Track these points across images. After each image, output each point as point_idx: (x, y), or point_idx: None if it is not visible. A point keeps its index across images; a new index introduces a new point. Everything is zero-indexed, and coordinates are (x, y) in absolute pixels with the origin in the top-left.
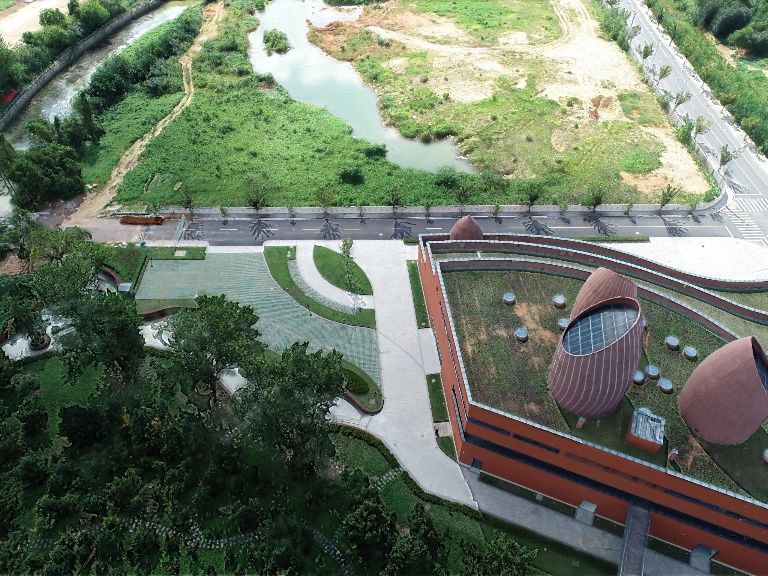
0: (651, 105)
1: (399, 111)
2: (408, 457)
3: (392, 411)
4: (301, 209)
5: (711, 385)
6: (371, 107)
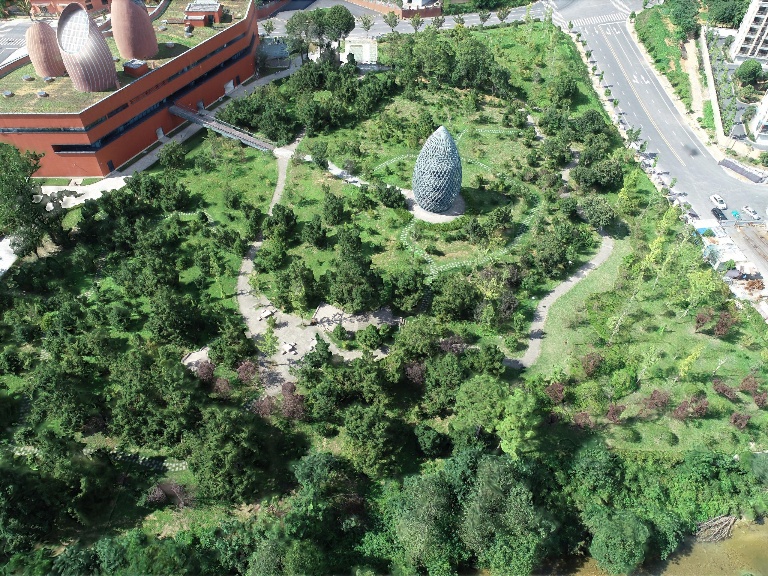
0: None
1: None
2: None
3: None
4: None
5: (128, 26)
6: None
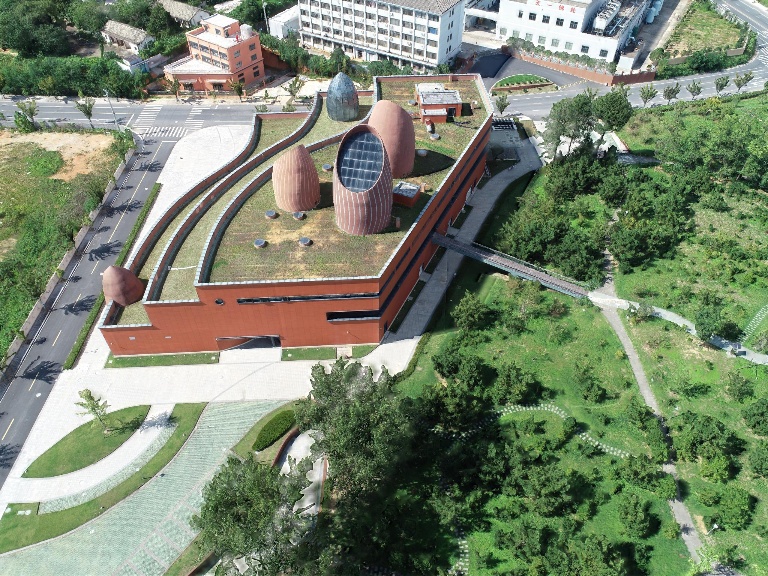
0: None
1: None
2: None
3: None
4: None
5: (396, 140)
6: None
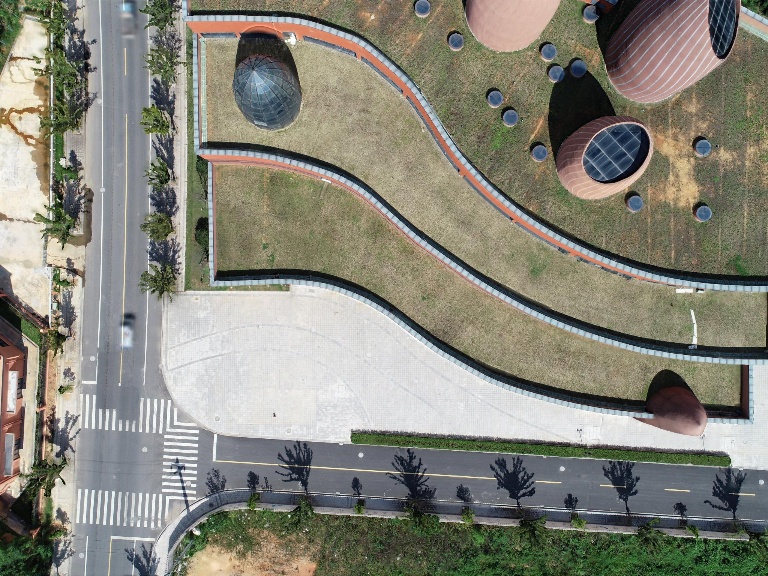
0: None
1: None
2: None
3: None
4: None
5: None
6: None
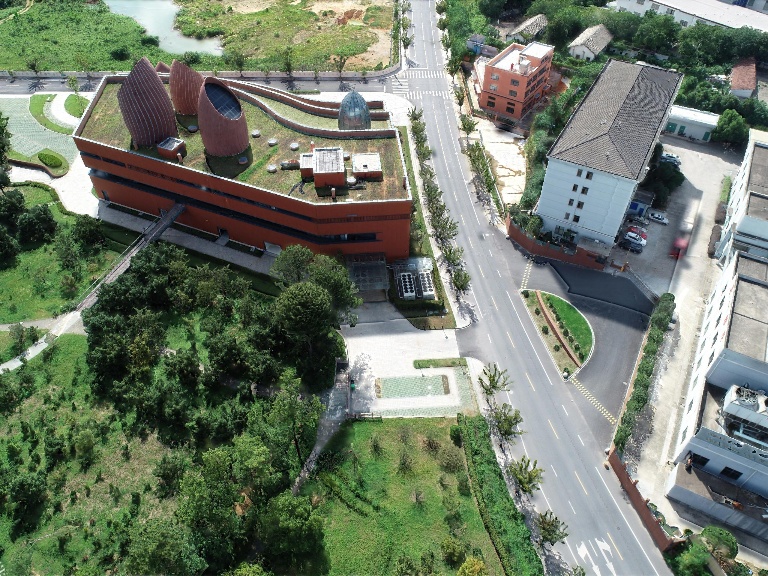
0: (387, 15)
1: (186, 18)
2: (68, 196)
3: (71, 176)
4: (71, 73)
5: None
6: (170, 17)
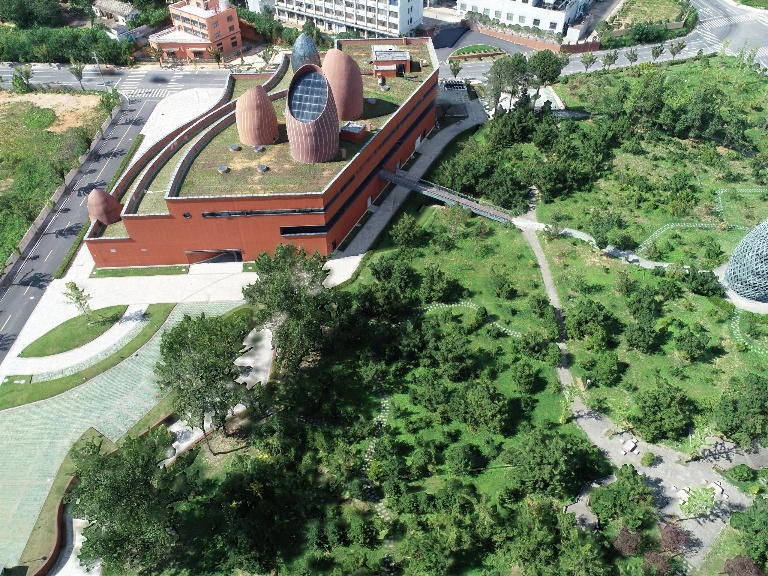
0: None
1: None
2: None
3: None
4: None
5: (344, 85)
6: None
